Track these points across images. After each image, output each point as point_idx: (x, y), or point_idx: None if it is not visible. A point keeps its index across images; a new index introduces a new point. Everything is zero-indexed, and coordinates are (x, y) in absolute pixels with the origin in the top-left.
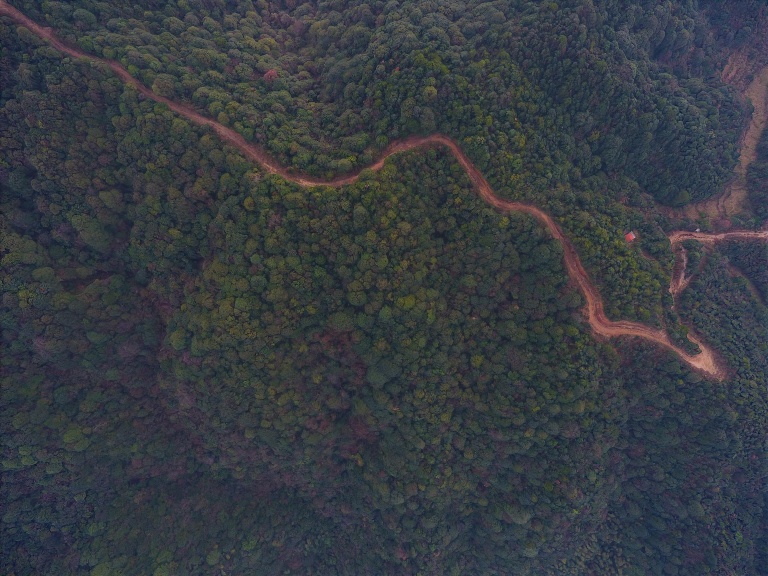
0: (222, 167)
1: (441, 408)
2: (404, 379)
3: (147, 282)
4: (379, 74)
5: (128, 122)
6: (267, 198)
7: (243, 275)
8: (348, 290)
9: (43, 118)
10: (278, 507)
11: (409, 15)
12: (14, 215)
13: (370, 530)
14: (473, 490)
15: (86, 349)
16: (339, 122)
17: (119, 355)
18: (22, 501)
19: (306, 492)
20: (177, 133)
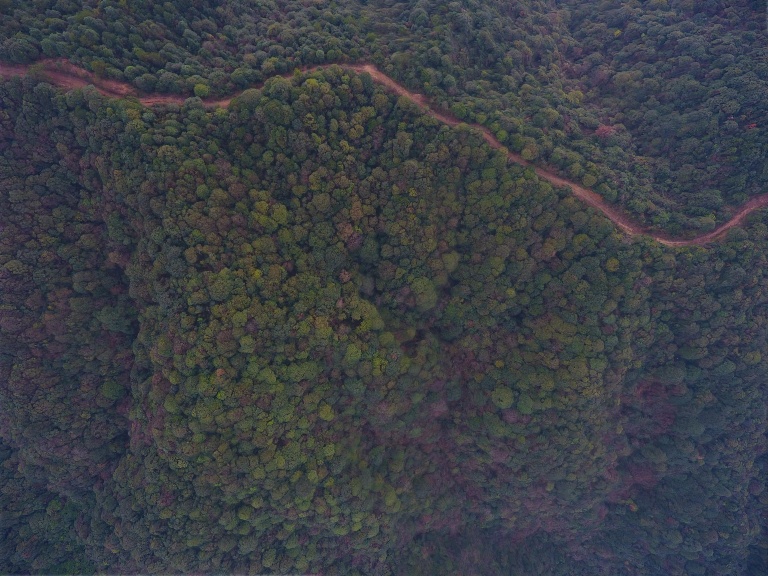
0: (580, 228)
1: (747, 455)
2: (721, 429)
3: (453, 338)
4: (728, 130)
5: (492, 186)
6: (640, 260)
7: (599, 336)
8: (688, 345)
9: (419, 187)
10: (536, 553)
11: (752, 69)
12: (362, 281)
13: (633, 574)
14: (757, 533)
15: (407, 410)
16: (677, 177)
17: (425, 413)
18: (337, 566)
19: (564, 537)
20: (541, 196)
